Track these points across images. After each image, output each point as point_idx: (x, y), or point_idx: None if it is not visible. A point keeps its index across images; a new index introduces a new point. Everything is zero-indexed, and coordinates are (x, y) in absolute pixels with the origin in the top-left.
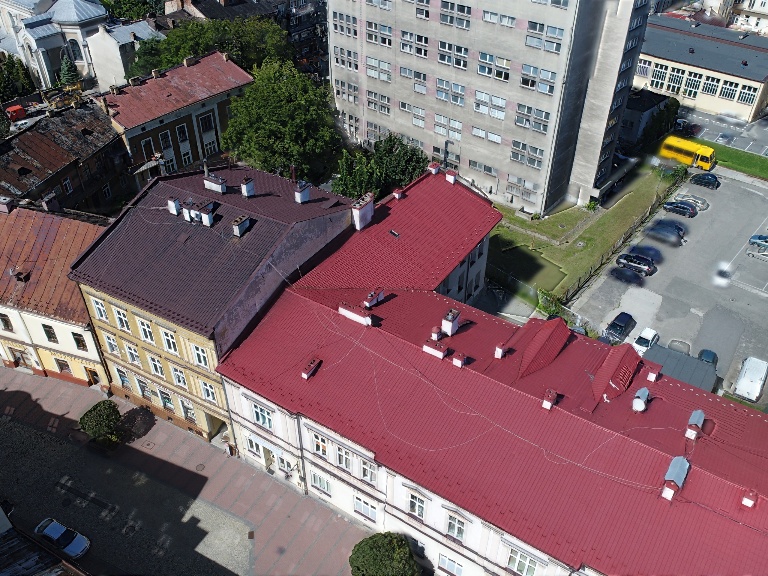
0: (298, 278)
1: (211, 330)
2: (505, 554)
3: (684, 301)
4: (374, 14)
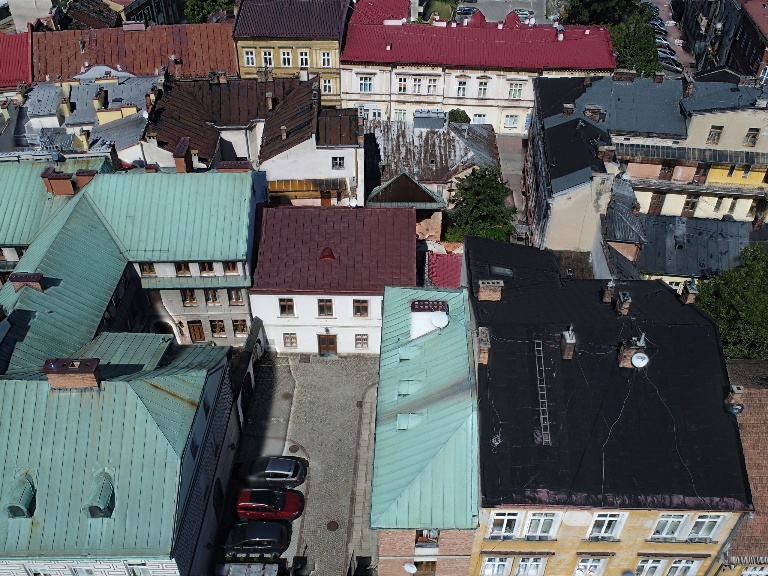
0: (349, 20)
1: (338, 34)
2: (508, 89)
3: None
4: None
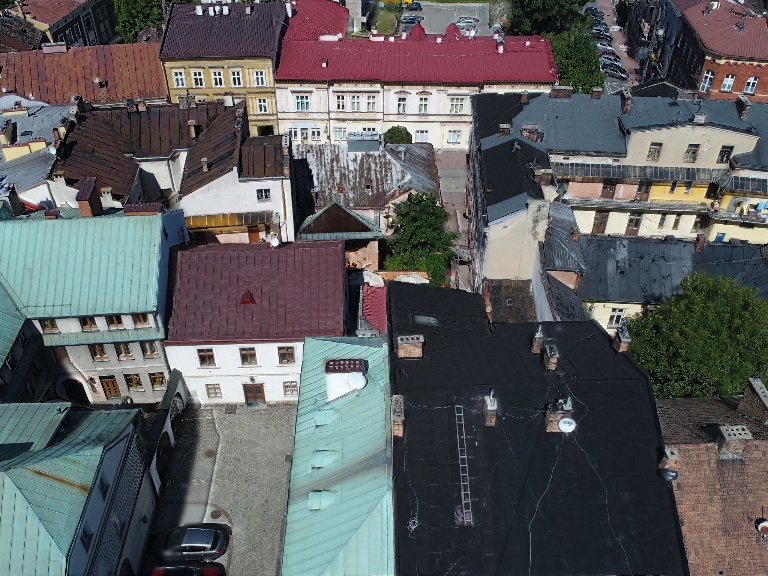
0: (283, 36)
1: (271, 52)
2: (449, 104)
3: None
4: None
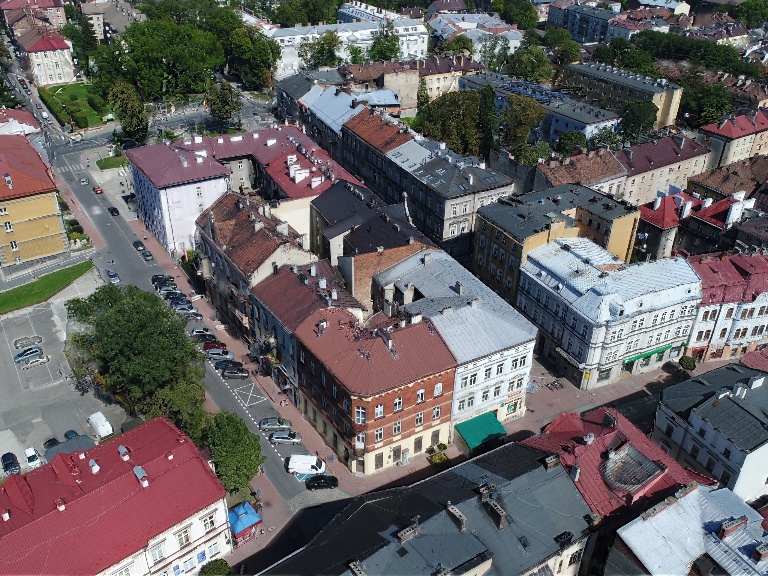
0: None
1: None
2: None
3: (23, 421)
4: None
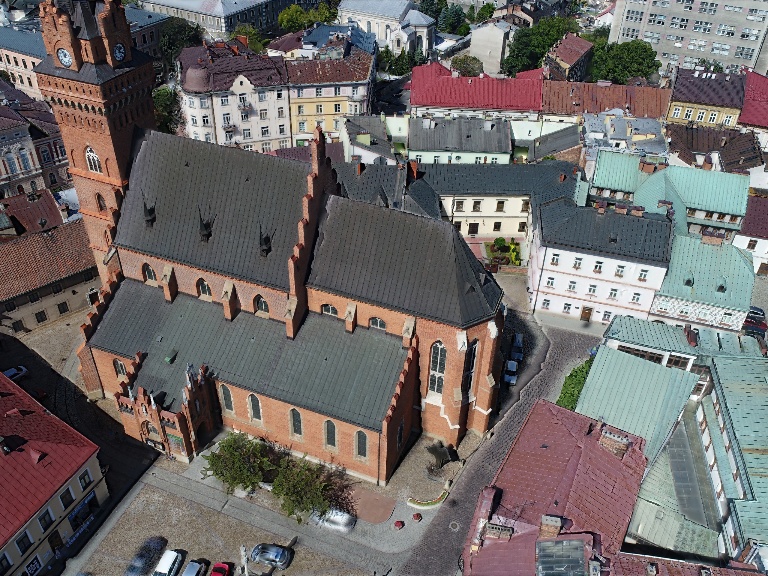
0: None
1: (742, 106)
2: None
3: None
4: (657, 10)
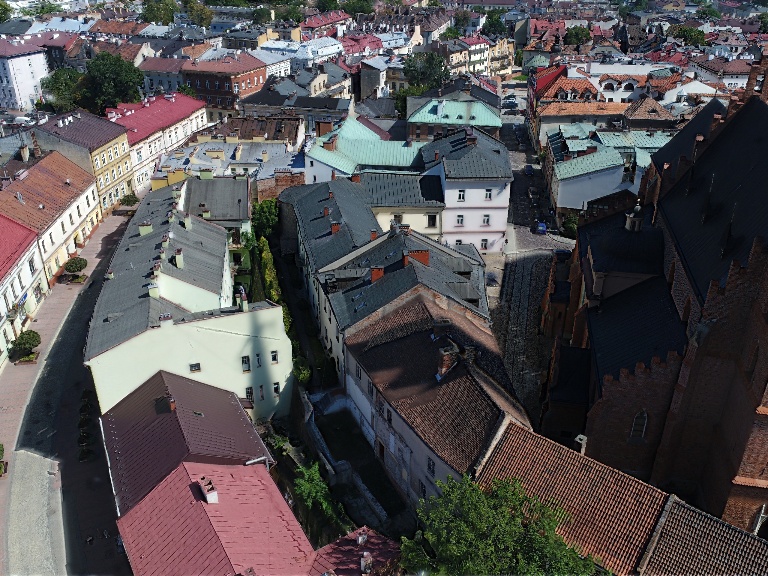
0: None
1: None
2: None
3: None
4: None
